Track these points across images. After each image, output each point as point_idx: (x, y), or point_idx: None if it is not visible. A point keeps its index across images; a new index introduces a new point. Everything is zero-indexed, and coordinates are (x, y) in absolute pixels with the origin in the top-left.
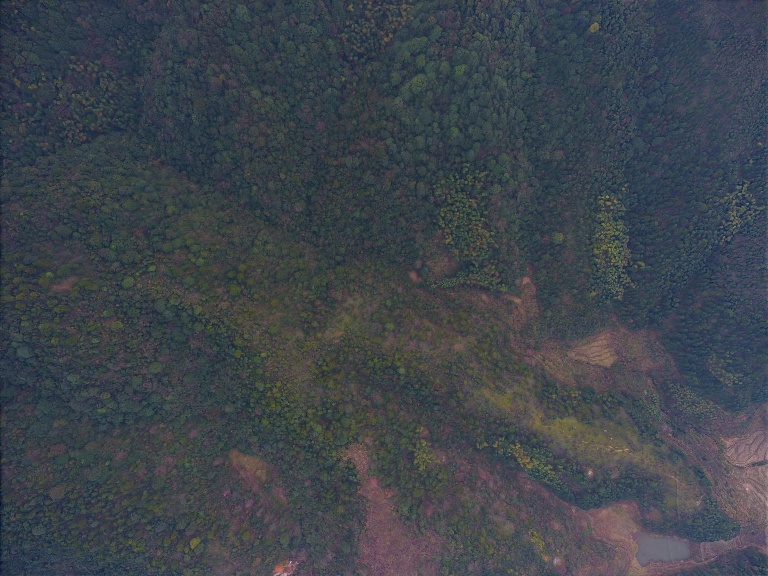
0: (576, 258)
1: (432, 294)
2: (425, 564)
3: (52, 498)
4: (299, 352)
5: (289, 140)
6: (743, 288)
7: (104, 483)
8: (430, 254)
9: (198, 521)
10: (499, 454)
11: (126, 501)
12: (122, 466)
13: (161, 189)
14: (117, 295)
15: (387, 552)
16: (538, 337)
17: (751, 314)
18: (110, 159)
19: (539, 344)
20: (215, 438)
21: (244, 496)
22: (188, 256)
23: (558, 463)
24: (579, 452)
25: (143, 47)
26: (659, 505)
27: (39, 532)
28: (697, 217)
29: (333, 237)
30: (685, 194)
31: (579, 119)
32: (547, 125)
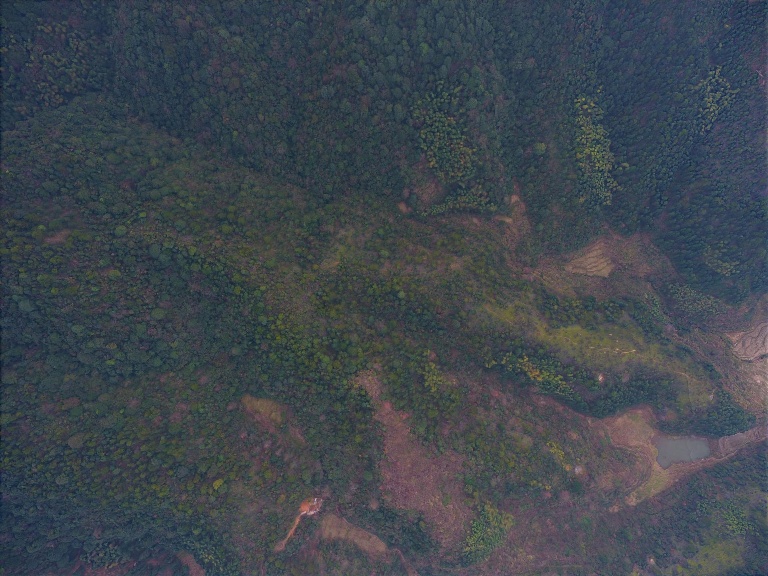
0: (560, 166)
1: (423, 223)
2: (448, 484)
3: (71, 447)
4: (298, 284)
5: (263, 80)
6: (728, 174)
7: (121, 430)
8: (416, 181)
9: (219, 464)
10: (508, 371)
11: (145, 446)
12: (137, 414)
13: (143, 143)
14: (111, 244)
15: (409, 474)
16: (533, 253)
17: (739, 199)
18: (89, 117)
19: (535, 261)
20: (226, 384)
21: (261, 438)
22: (177, 201)
23: (568, 372)
24: (587, 358)
25: (108, 6)
26: (673, 404)
27: (62, 481)
28: (674, 108)
29: (318, 175)
30: (660, 87)
31: (546, 22)
32: (515, 33)
